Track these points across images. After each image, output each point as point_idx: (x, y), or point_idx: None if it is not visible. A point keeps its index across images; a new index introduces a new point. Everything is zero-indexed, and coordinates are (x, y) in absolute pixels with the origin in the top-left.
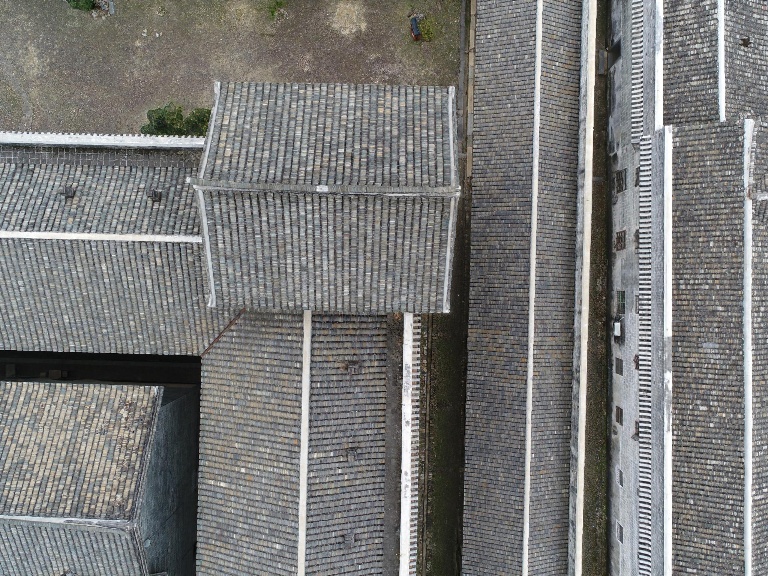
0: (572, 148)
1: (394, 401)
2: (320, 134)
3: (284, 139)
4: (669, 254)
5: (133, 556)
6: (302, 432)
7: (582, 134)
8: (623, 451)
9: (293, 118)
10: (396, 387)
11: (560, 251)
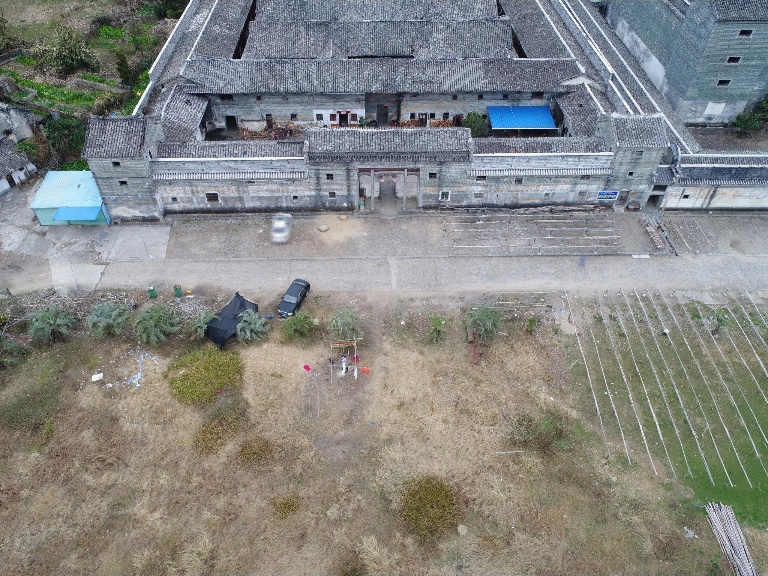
0: None
1: None
2: (753, 5)
3: (762, 4)
4: None
5: None
6: None
7: None
8: None
9: (762, 9)
10: None
11: None
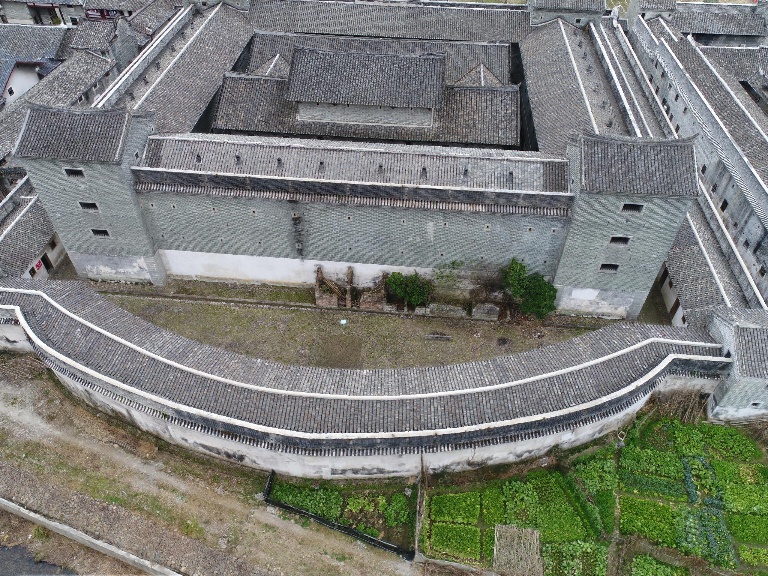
0: (629, 65)
1: (590, 44)
2: None
3: None
4: (674, 55)
5: (507, 57)
6: (564, 34)
7: (631, 59)
8: (683, 133)
9: None
10: (590, 42)
11: (633, 80)
